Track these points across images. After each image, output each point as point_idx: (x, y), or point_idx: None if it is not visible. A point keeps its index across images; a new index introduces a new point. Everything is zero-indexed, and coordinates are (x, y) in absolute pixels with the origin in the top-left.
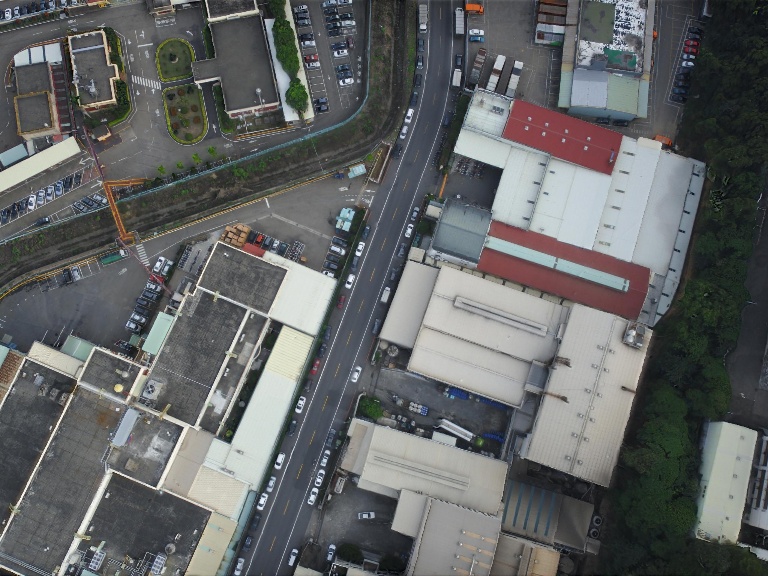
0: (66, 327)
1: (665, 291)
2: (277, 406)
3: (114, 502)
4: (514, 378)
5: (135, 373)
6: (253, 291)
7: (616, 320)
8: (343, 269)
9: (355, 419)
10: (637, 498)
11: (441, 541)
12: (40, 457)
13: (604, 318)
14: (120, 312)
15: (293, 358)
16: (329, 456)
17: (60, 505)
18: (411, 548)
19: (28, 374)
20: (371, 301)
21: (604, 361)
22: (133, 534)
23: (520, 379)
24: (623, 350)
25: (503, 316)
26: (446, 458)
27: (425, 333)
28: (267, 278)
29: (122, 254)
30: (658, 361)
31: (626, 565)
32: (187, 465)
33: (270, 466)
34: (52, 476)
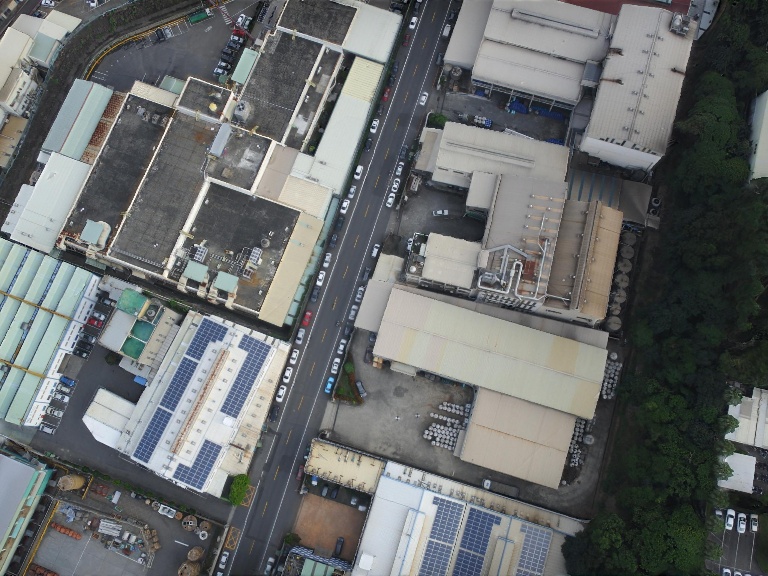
0: (161, 76)
1: (706, 9)
2: (354, 124)
3: (213, 208)
4: (570, 77)
5: (226, 97)
6: (327, 28)
7: (663, 12)
8: (406, 12)
9: (426, 128)
10: (692, 161)
11: (512, 206)
12: (146, 171)
13: (651, 12)
14: (208, 62)
15: (366, 83)
16: (403, 166)
17: (166, 209)
18: (484, 230)
19: (131, 107)
20: (433, 39)
21: (654, 47)
22: (231, 234)
23: (576, 78)
24: (671, 38)
25: (557, 21)
26: (512, 144)
27: (486, 45)
28: (339, 17)
29: (208, 12)
30: (704, 56)
31: (686, 221)
32: (276, 176)
33: (350, 177)
34: (157, 186)
